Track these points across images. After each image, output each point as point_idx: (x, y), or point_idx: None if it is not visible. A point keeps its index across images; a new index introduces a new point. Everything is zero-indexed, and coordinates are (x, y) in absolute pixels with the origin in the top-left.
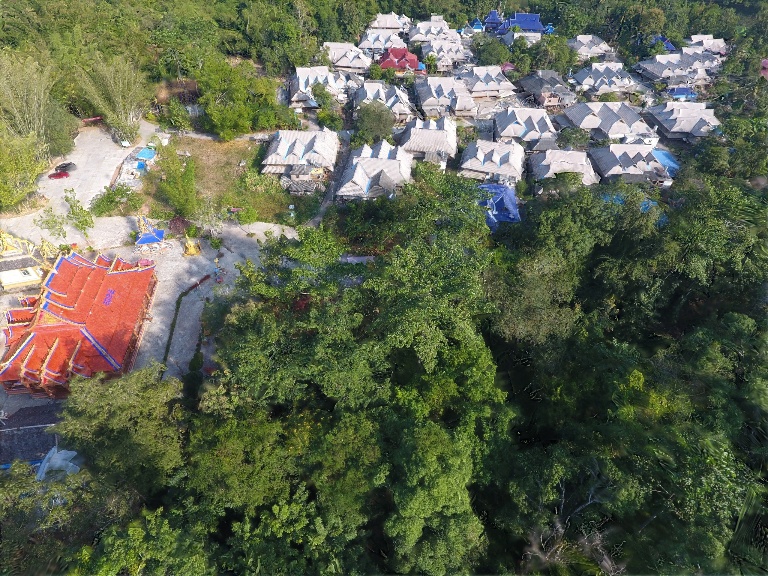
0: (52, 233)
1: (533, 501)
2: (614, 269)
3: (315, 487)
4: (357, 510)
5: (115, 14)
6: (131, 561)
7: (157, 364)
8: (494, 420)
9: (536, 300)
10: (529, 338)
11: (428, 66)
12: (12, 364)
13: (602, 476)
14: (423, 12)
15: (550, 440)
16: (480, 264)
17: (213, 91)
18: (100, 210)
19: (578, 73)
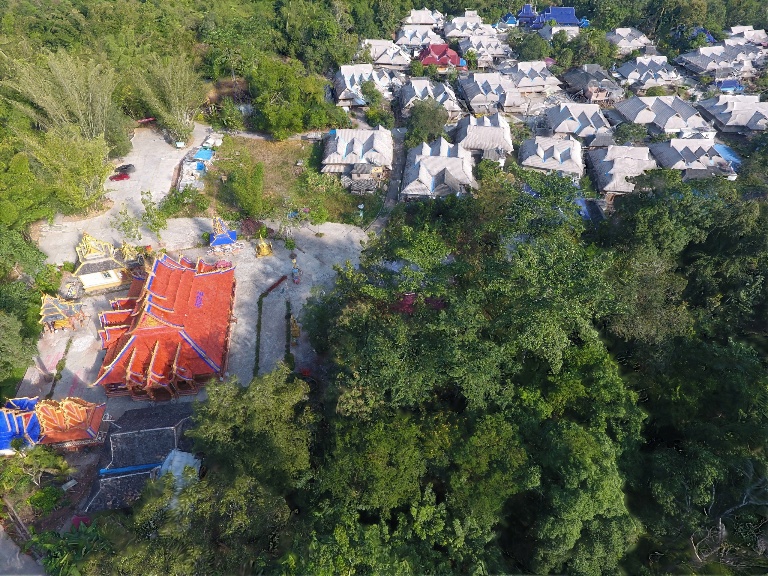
0: (128, 235)
1: (680, 502)
2: (709, 266)
3: (441, 488)
4: (493, 512)
5: (158, 14)
6: (341, 567)
7: (283, 367)
8: (623, 421)
9: (652, 299)
10: (646, 338)
11: (468, 62)
12: (114, 367)
13: (758, 477)
14: (456, 7)
15: (674, 440)
16: (606, 264)
17: (268, 91)
18: (168, 212)
19: (622, 67)
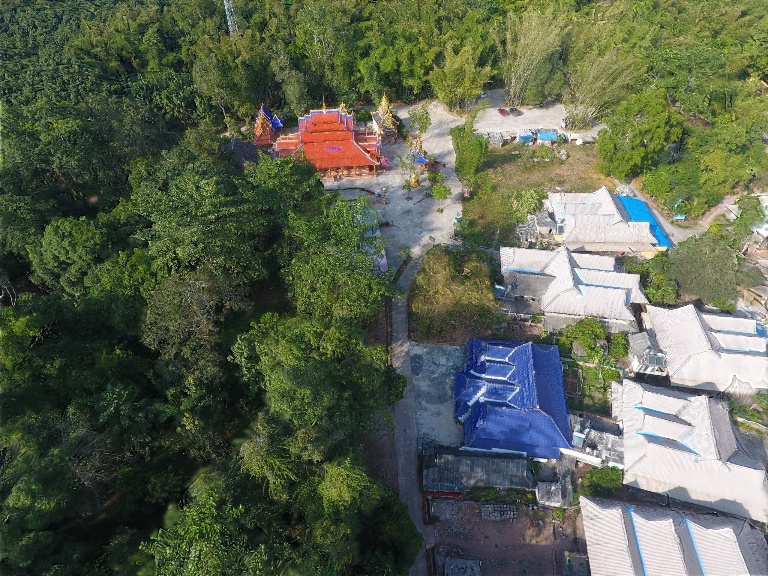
0: None
1: None
2: None
3: None
4: None
5: (767, 38)
6: None
7: (216, 146)
8: None
9: None
10: None
11: None
12: None
13: None
14: None
15: None
16: None
17: None
18: None
19: None
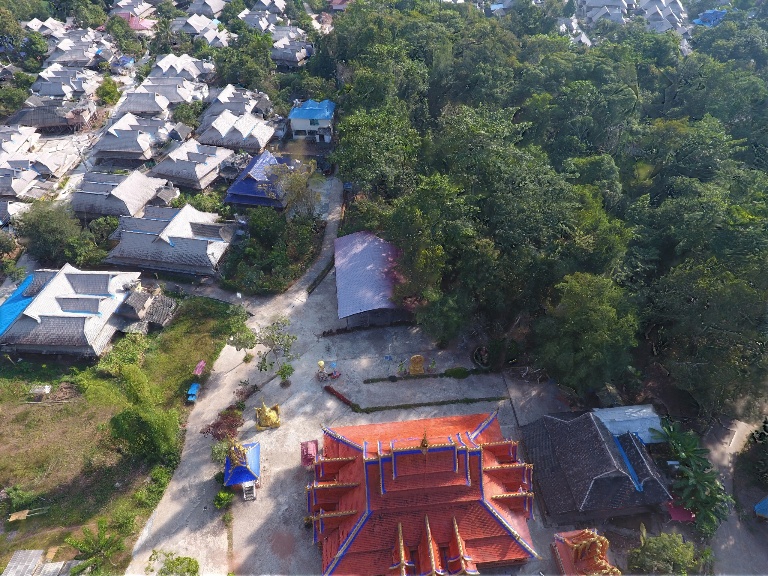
0: None
1: None
2: None
3: None
4: None
5: None
6: None
7: None
8: None
9: None
10: None
11: None
12: None
13: None
14: None
15: None
16: None
17: None
18: None
19: (41, 89)
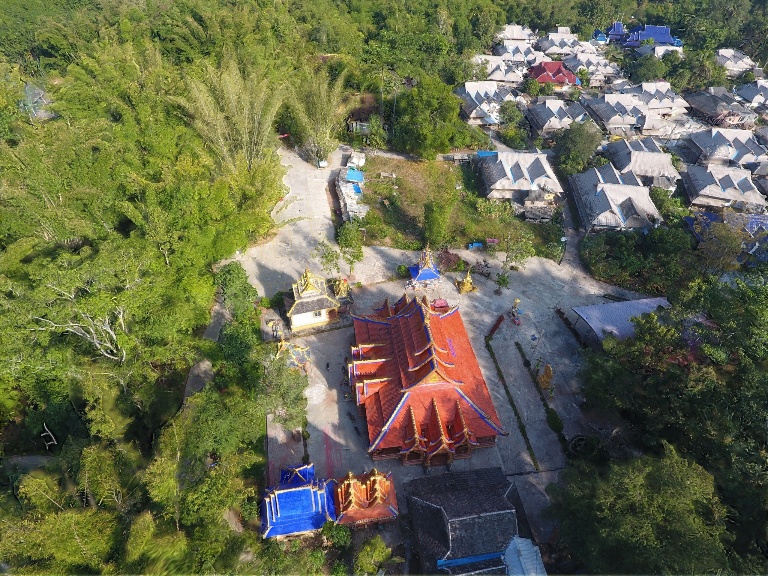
0: (325, 268)
1: None
2: None
3: None
4: None
5: None
6: None
7: None
8: None
9: None
10: None
11: None
12: (389, 428)
13: None
14: (545, 23)
15: None
16: None
17: None
18: None
19: (743, 90)
